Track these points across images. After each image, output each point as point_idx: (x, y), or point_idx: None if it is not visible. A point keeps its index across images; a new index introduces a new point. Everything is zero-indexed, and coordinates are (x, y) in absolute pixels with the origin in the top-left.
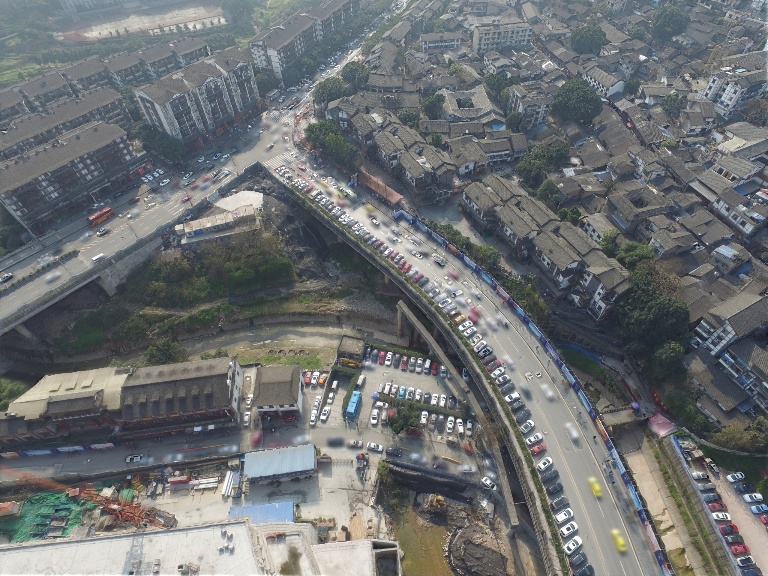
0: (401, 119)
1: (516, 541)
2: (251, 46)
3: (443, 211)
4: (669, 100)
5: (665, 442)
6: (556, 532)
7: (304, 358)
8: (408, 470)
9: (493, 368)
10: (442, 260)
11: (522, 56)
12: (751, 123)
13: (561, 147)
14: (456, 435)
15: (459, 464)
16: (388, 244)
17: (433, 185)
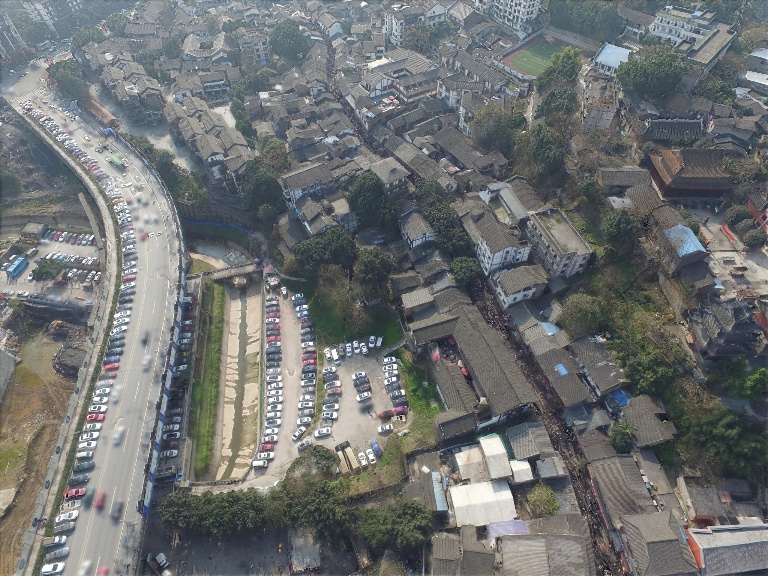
0: (137, 58)
1: None
2: (22, 1)
3: (153, 129)
4: None
5: None
6: (111, 325)
7: (6, 246)
8: (38, 305)
9: (124, 231)
10: (127, 163)
11: (276, 7)
12: (413, 50)
13: (258, 74)
14: (91, 282)
15: (85, 300)
16: (88, 154)
17: (141, 107)
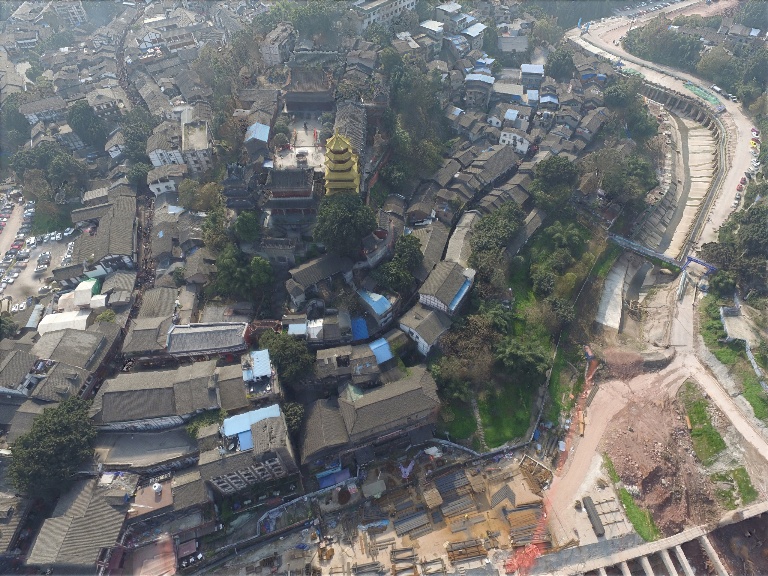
0: None
1: None
2: None
3: None
4: None
5: None
6: None
7: None
8: None
9: None
10: None
11: None
12: (197, 11)
13: (60, 32)
14: None
15: None
16: None
17: None
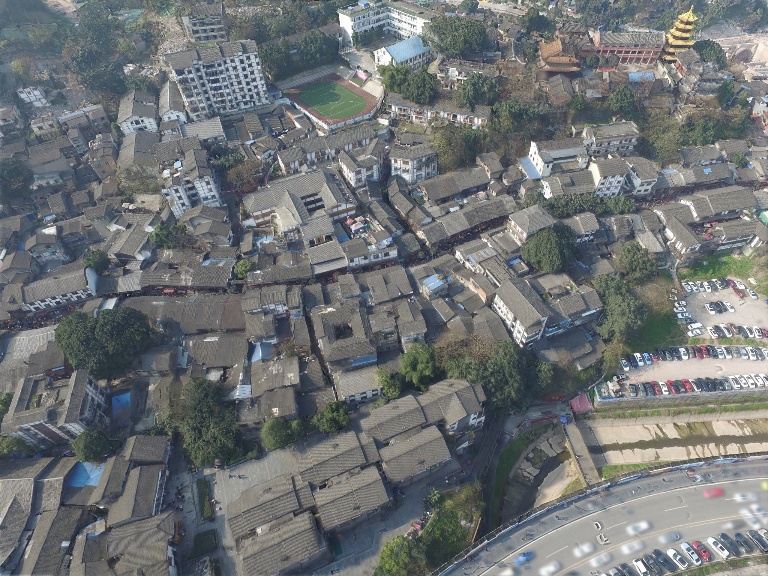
0: None
1: None
2: None
3: None
4: (164, 238)
5: (599, 406)
6: None
7: None
8: None
9: None
10: None
11: None
12: (244, 191)
13: (201, 389)
14: None
15: None
16: None
17: None
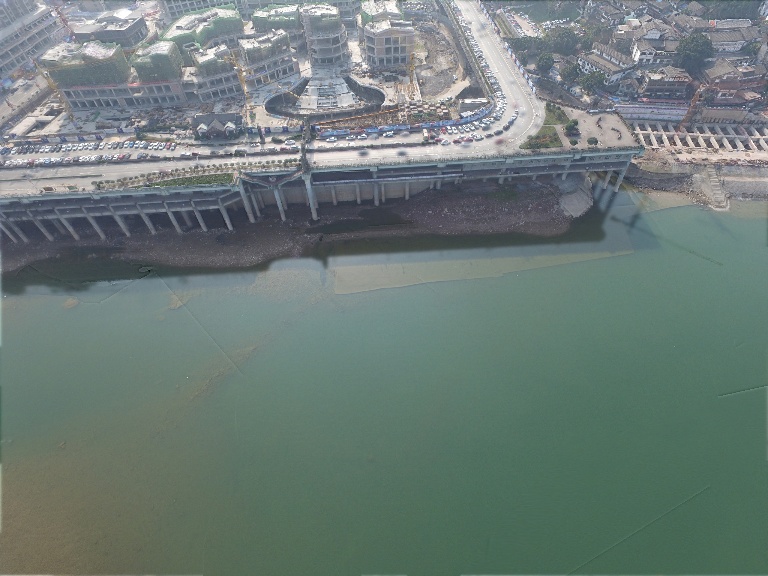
0: None
1: (439, 23)
2: None
3: None
4: None
5: None
6: (450, 6)
7: None
8: None
9: None
10: None
11: None
12: None
13: None
14: None
15: None
16: None
17: None
